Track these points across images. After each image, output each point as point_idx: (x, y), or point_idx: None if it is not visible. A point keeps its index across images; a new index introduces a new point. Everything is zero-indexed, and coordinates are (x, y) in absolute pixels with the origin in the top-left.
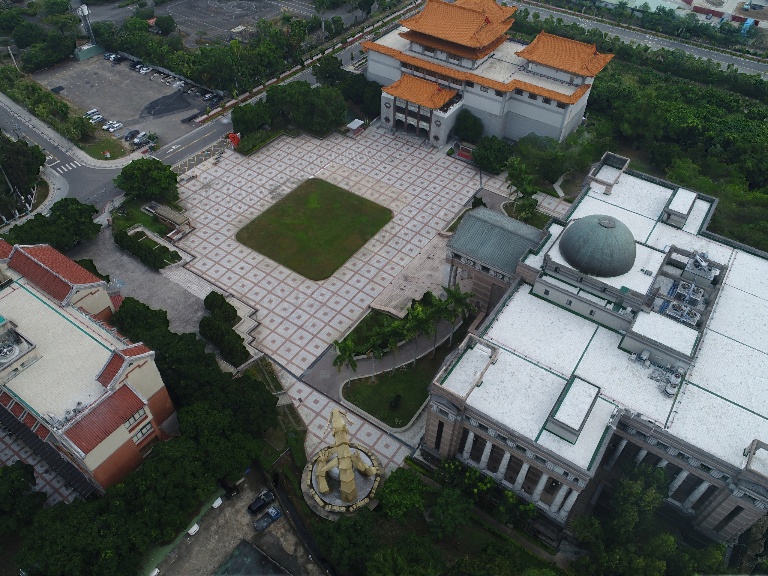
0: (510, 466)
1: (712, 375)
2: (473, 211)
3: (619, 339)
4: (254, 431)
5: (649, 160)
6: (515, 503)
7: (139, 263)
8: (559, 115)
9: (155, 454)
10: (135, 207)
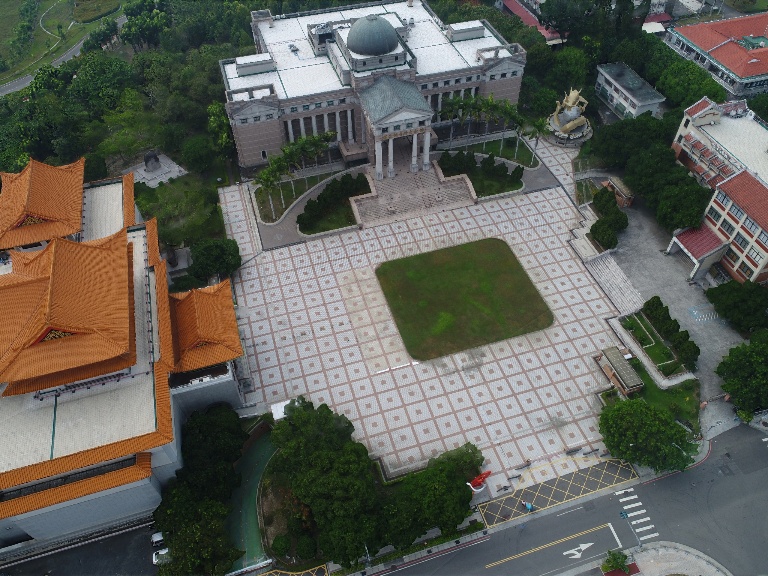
0: None
1: None
2: (395, 111)
3: None
4: None
5: None
6: None
7: None
8: None
9: None
10: None
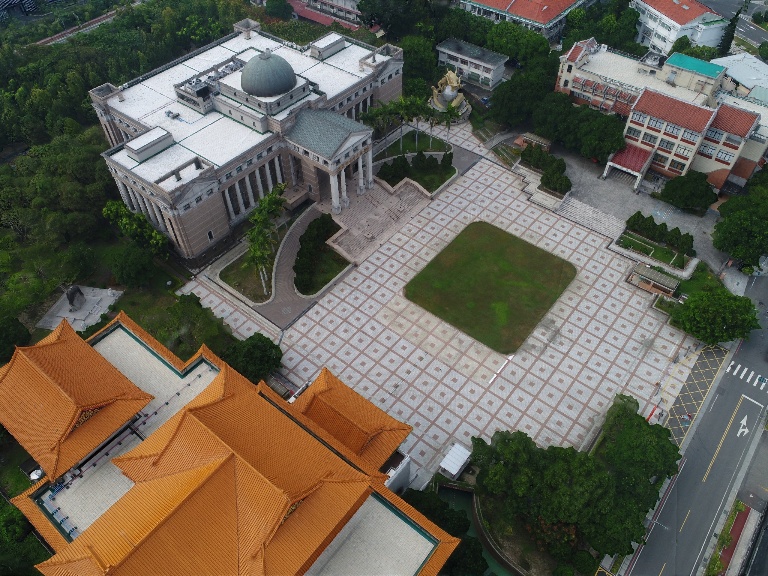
0: None
1: None
2: (344, 139)
3: None
4: None
5: None
6: None
7: None
8: None
9: None
10: None
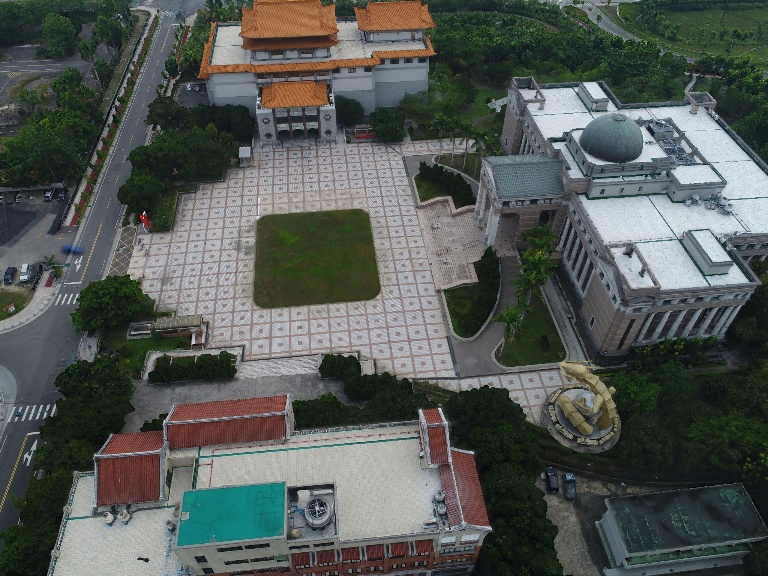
0: (665, 327)
1: (729, 189)
2: (490, 162)
3: (667, 197)
4: (519, 425)
5: (484, 82)
6: (701, 344)
7: (201, 384)
8: (422, 69)
9: (484, 499)
10: (116, 340)
